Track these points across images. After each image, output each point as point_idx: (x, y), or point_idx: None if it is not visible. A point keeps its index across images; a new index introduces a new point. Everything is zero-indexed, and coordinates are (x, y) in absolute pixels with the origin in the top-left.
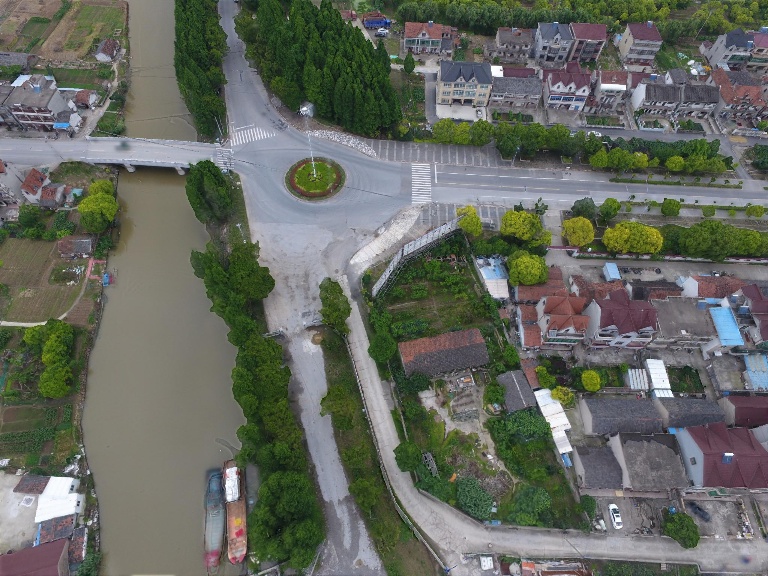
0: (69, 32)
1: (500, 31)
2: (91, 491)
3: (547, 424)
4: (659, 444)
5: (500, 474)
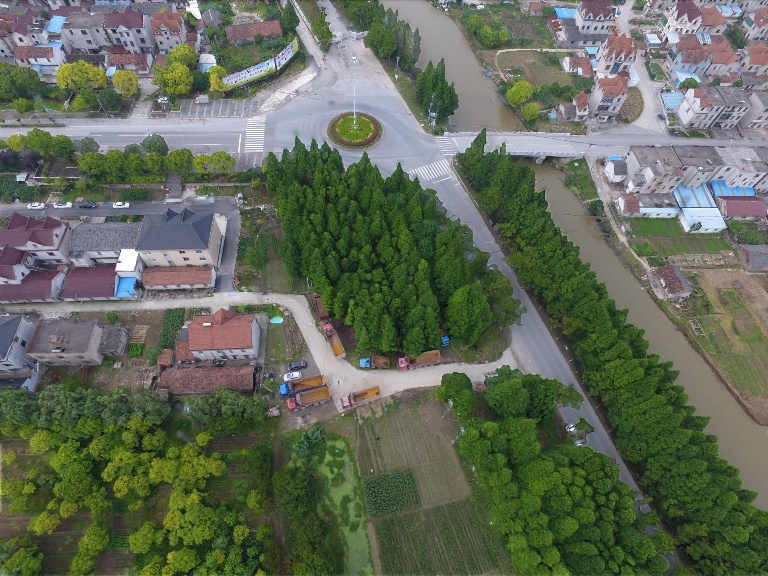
0: (763, 325)
1: None
2: (433, 3)
3: (199, 6)
4: None
5: (231, 1)
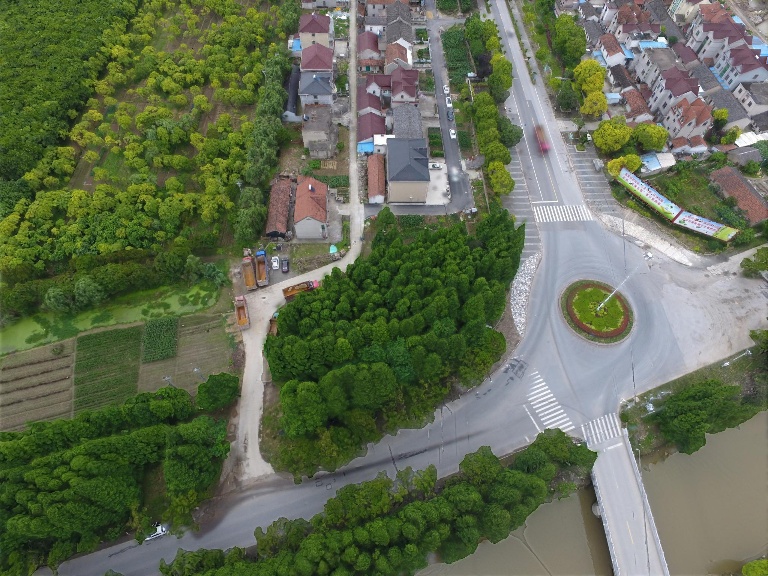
0: None
1: (306, 131)
2: None
3: (760, 142)
4: (751, 89)
5: None
